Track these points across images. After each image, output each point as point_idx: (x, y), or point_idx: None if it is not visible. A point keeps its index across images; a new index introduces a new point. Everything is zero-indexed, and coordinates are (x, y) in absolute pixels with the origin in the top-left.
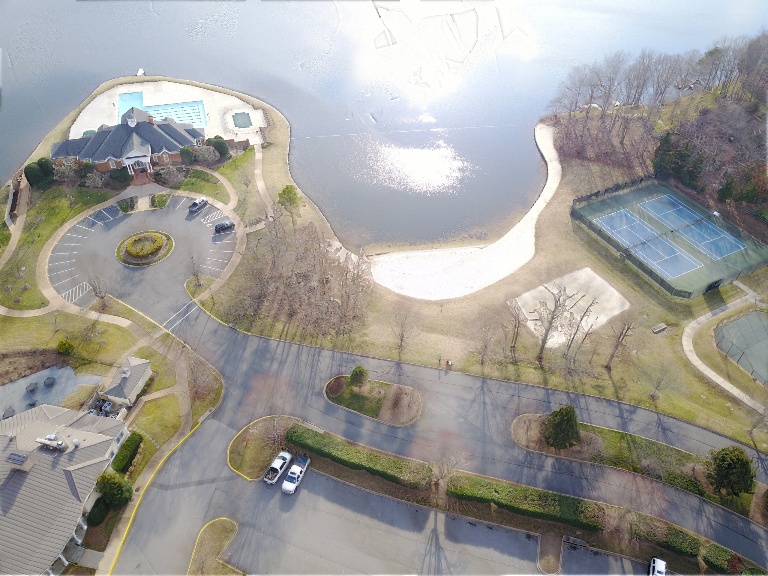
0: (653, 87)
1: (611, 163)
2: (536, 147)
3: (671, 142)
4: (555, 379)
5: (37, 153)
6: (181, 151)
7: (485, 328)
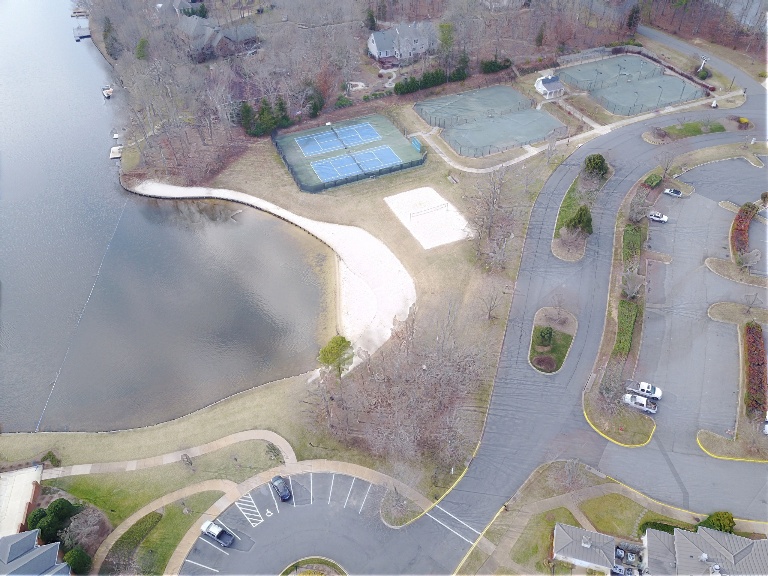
0: (160, 93)
1: (236, 157)
2: (175, 200)
3: (251, 109)
4: (517, 232)
5: None
6: (76, 564)
7: None
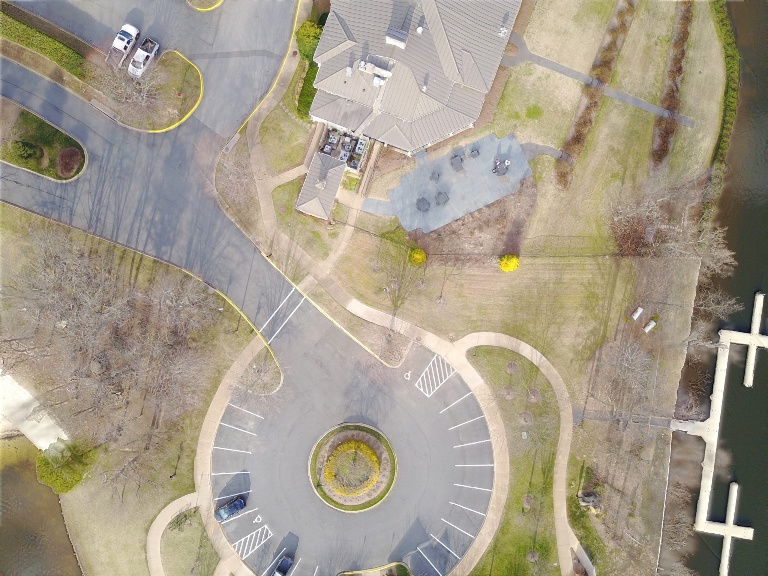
0: None
1: None
2: None
3: None
4: None
5: None
6: None
7: None
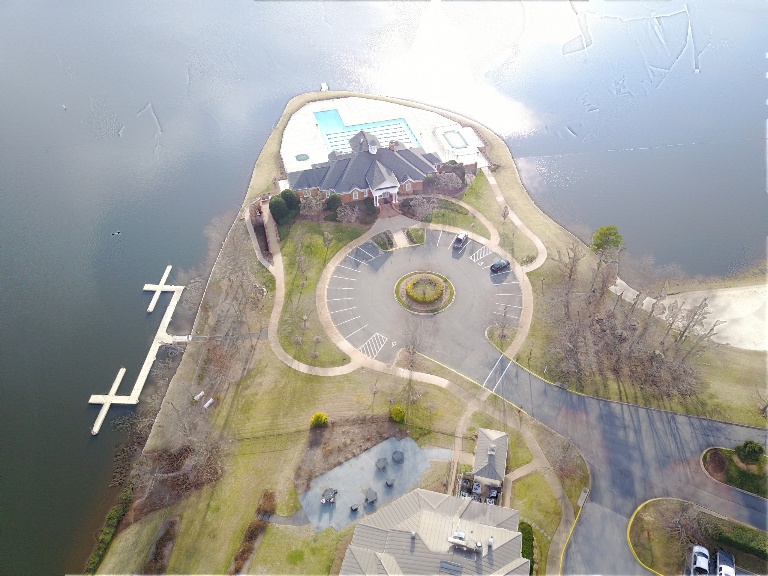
0: None
1: None
2: None
3: None
4: None
5: (256, 181)
6: (426, 179)
7: None
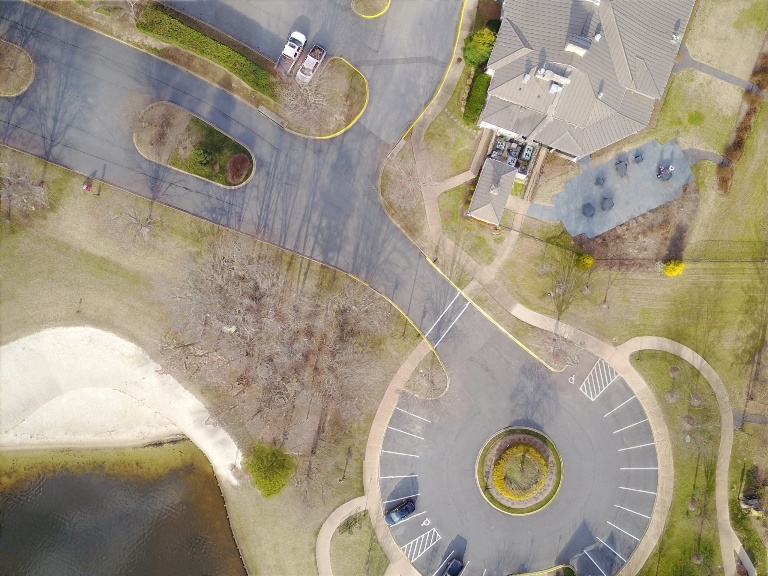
0: None
1: None
2: None
3: None
4: None
5: None
6: None
7: (4, 163)
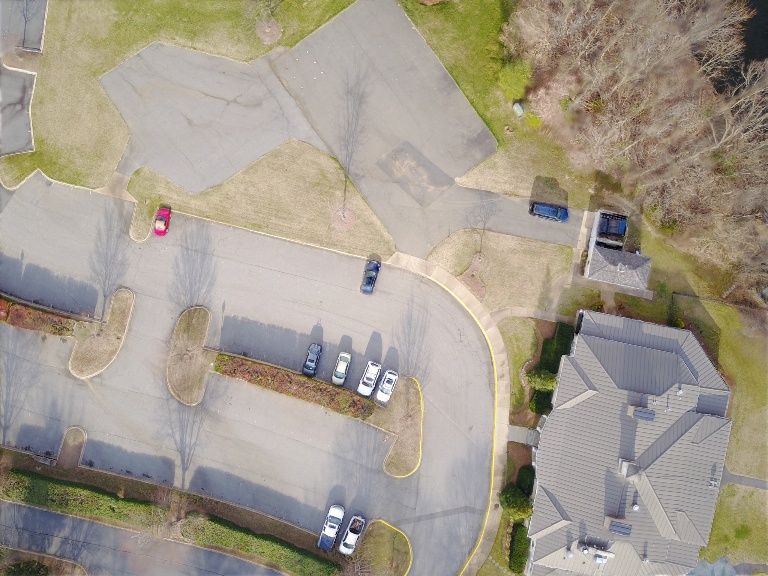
0: None
1: None
2: None
3: None
4: None
5: None
6: None
7: None
